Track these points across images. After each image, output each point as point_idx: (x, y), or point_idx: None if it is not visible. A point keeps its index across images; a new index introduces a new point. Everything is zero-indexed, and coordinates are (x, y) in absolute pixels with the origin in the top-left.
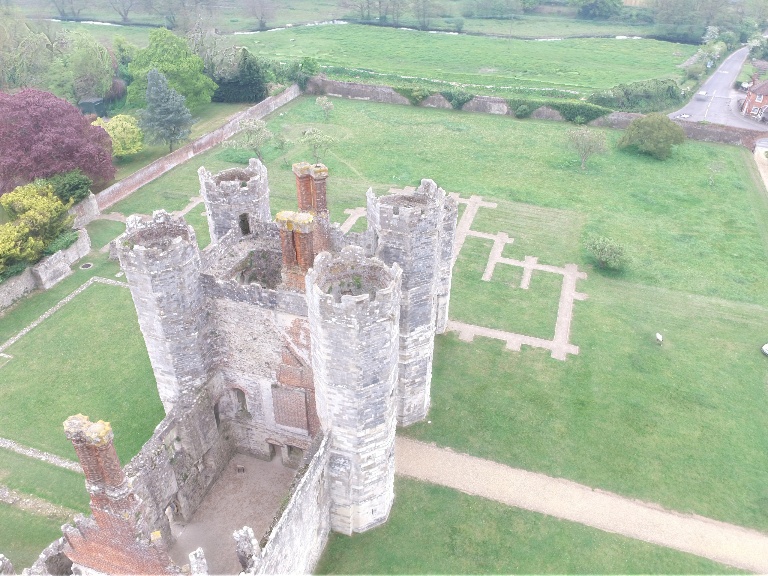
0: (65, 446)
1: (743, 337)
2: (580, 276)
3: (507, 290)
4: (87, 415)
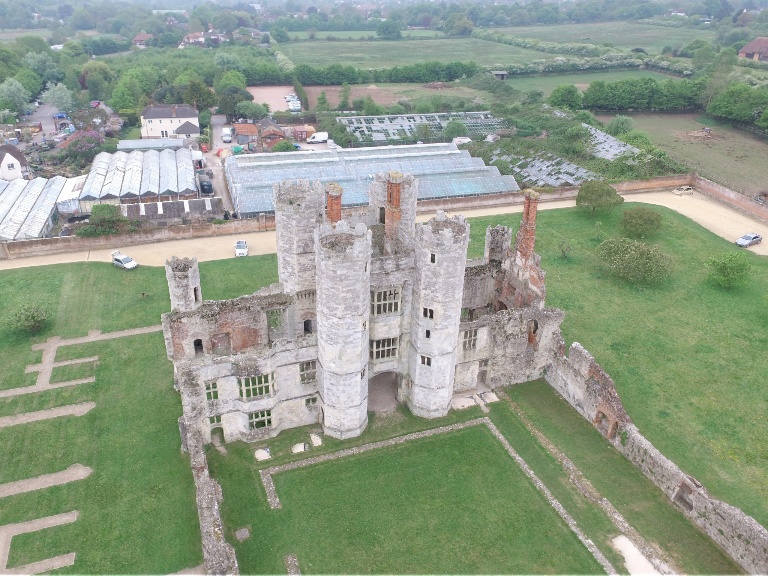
0: (513, 471)
1: (115, 277)
2: (57, 340)
3: (108, 363)
4: (485, 486)
